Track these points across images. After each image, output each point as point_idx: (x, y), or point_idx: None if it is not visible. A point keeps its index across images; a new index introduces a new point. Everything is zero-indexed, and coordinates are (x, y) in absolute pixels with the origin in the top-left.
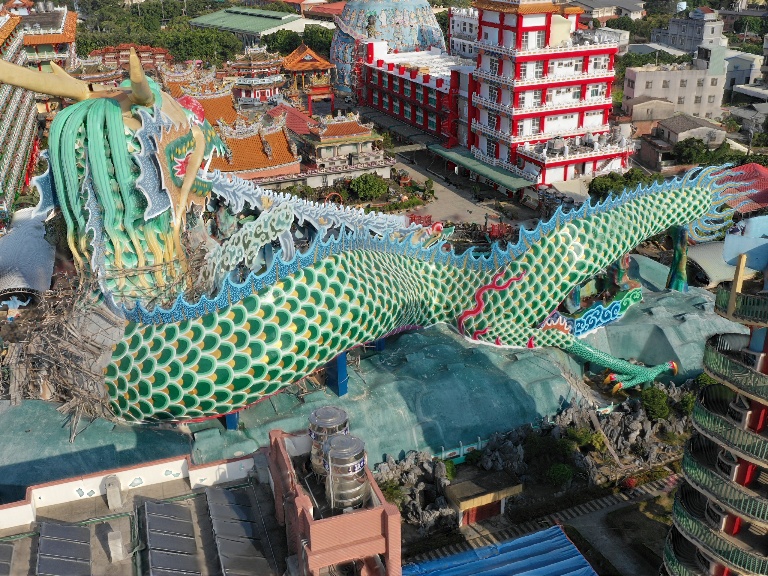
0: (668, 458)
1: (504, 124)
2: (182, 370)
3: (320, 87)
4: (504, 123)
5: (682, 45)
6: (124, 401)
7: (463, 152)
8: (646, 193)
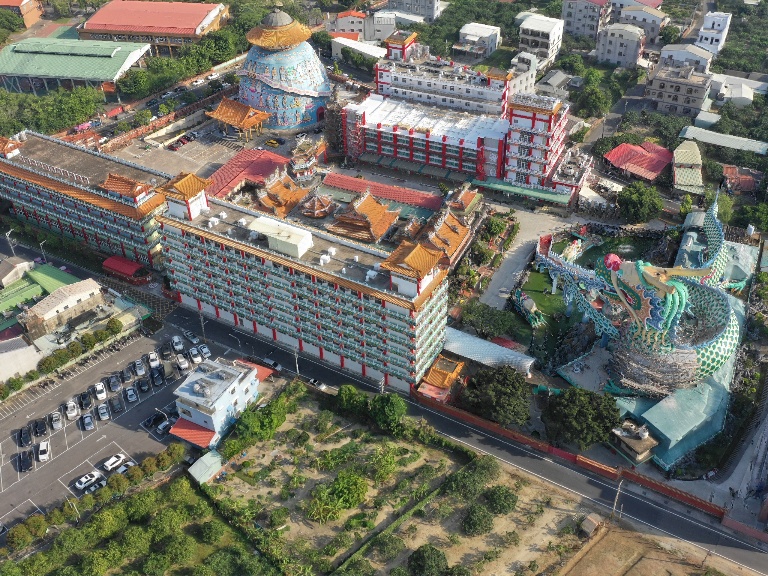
0: None
1: (535, 166)
2: None
3: None
4: (535, 166)
5: (417, 11)
6: None
7: (499, 182)
8: None
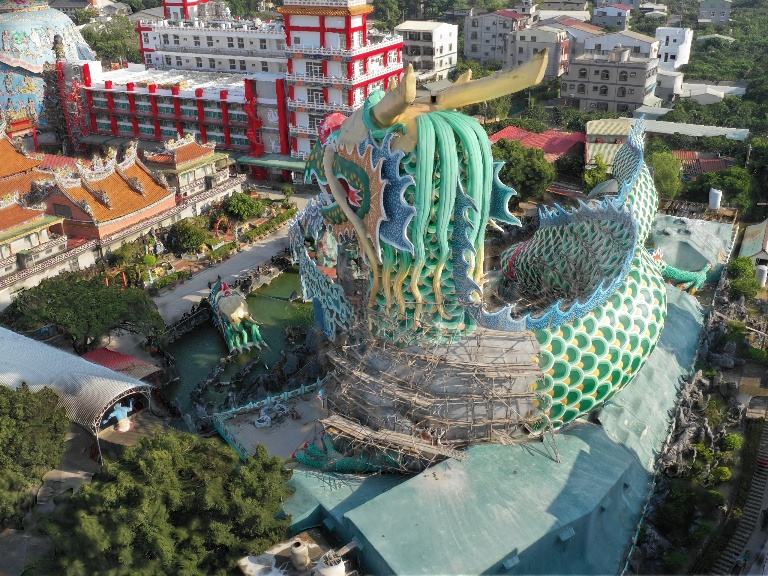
0: (764, 326)
1: None
2: (621, 353)
3: (20, 121)
4: None
5: None
6: (560, 409)
7: (282, 158)
8: None
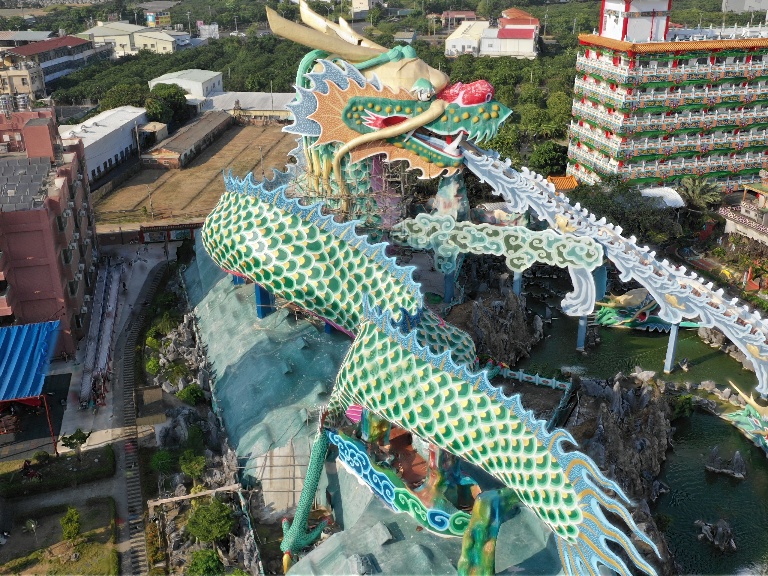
0: (174, 567)
1: None
2: None
3: None
4: None
5: None
6: None
7: None
8: (500, 398)
